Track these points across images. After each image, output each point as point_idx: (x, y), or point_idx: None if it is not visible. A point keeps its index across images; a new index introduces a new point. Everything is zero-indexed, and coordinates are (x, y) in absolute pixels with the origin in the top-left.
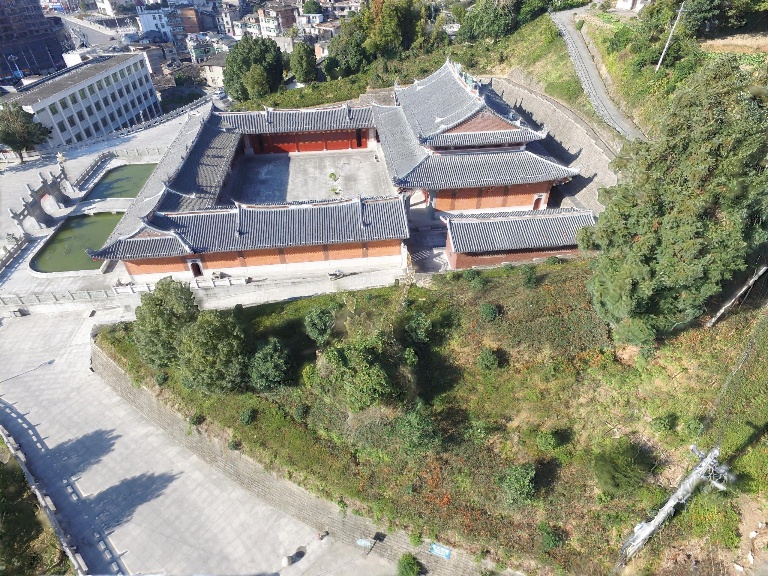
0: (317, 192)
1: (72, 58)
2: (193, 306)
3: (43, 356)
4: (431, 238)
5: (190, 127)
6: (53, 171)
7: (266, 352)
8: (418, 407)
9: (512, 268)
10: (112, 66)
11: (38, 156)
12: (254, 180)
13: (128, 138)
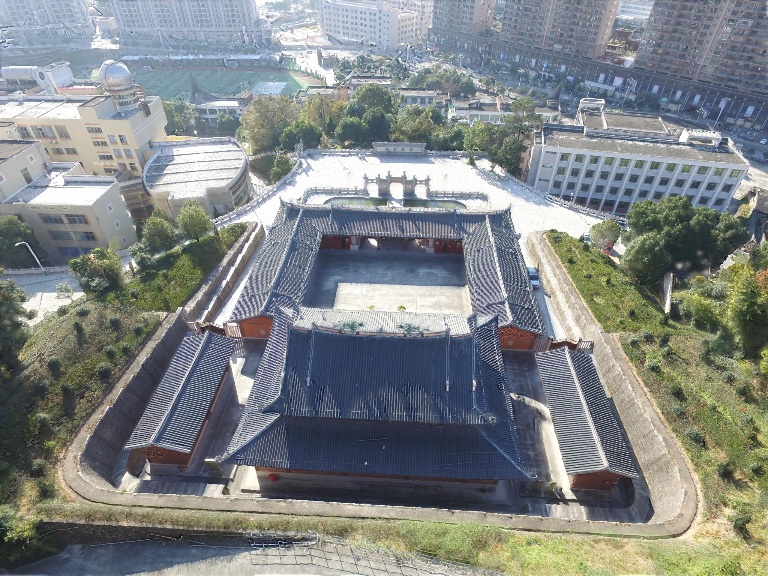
0: (382, 302)
1: (685, 135)
2: (192, 226)
3: (266, 220)
4: (260, 360)
5: (470, 211)
6: (475, 184)
7: (139, 245)
8: (67, 286)
9: (124, 349)
10: (686, 158)
11: (503, 174)
12: (416, 266)
13: (544, 203)
